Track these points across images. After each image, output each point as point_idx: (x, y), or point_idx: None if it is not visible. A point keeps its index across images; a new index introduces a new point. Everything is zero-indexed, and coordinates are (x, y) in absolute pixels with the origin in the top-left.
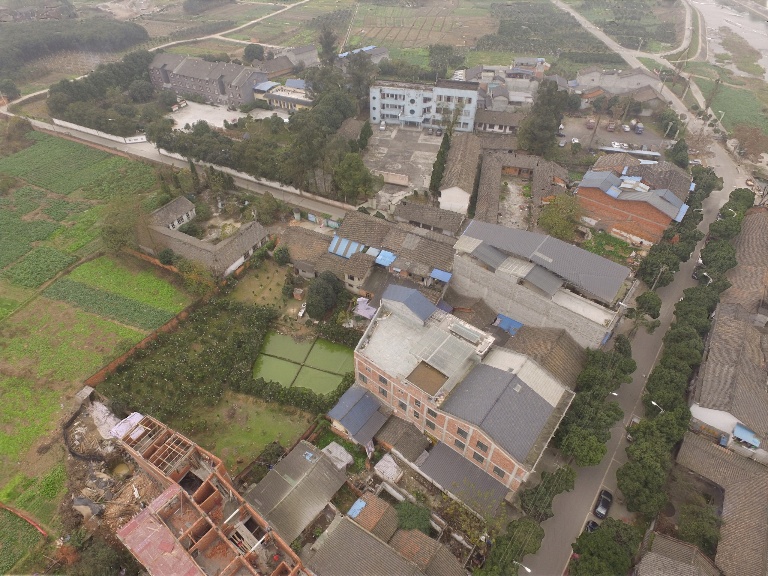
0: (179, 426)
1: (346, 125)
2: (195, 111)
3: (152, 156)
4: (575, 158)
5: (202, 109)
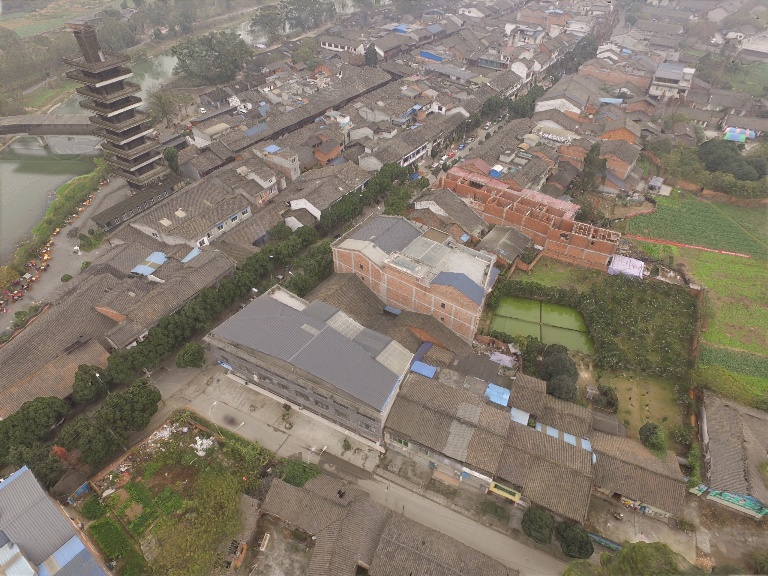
0: None
1: None
2: None
3: None
4: None
5: None
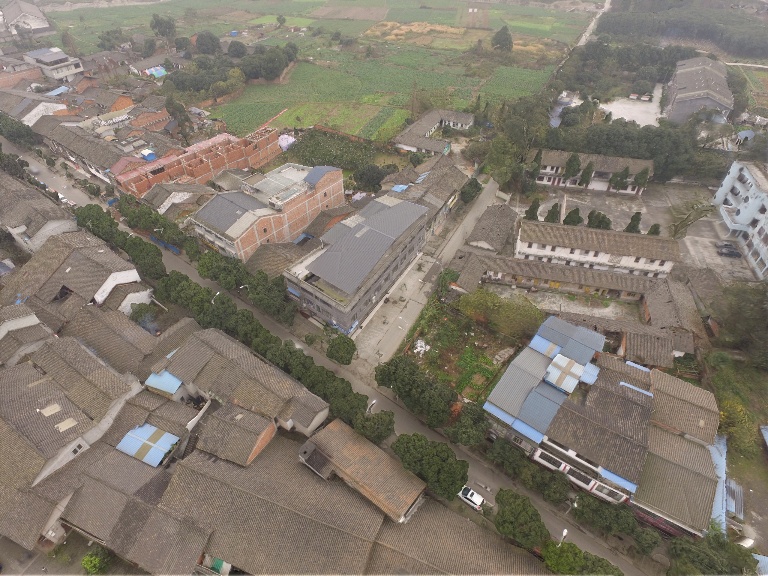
0: (289, 155)
1: (629, 159)
2: (641, 107)
3: None
4: (760, 409)
5: (649, 109)
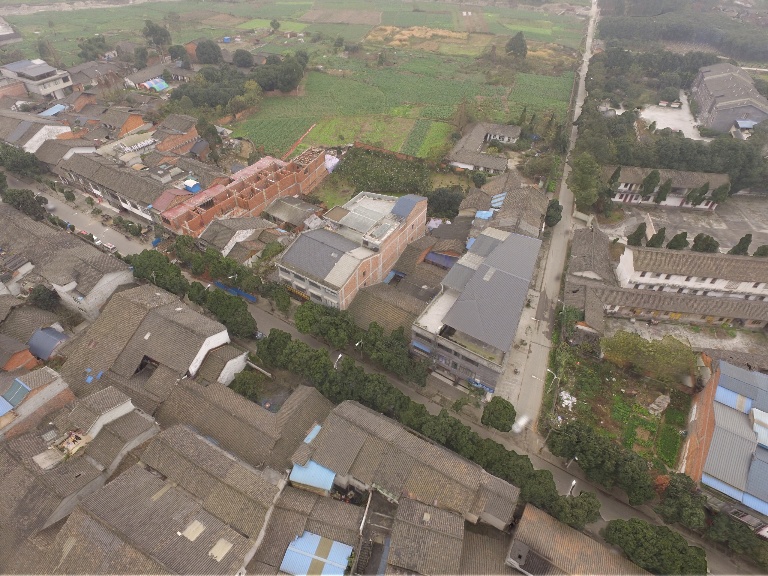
0: None
1: (704, 173)
2: (673, 114)
3: (579, 114)
4: None
5: (681, 116)
